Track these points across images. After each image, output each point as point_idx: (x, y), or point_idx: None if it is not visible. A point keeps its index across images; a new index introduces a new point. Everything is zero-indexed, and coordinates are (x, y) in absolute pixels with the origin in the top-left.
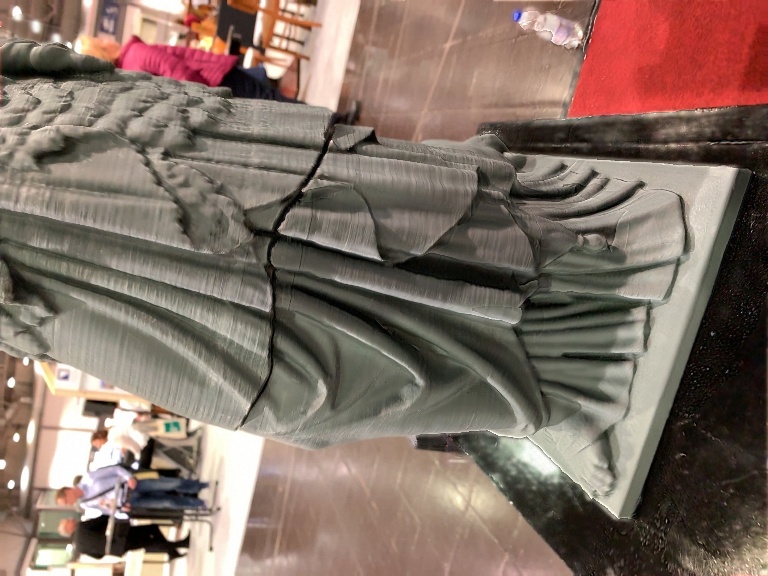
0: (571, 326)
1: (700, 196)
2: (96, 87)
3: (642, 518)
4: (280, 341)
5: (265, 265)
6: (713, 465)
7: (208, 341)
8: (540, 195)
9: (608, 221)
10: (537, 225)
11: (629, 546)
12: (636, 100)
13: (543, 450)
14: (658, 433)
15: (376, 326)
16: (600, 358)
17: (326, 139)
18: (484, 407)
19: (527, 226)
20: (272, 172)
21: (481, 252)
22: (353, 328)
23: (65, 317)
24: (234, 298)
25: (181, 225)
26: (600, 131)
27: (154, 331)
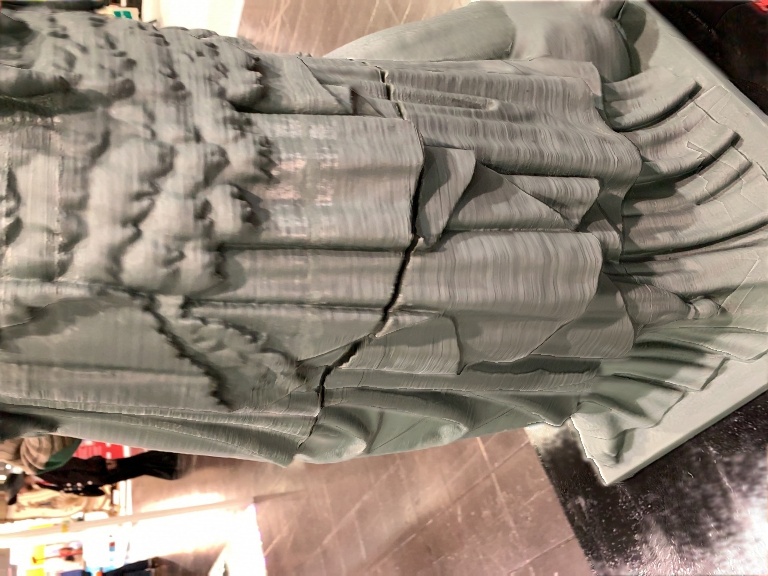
0: (634, 355)
1: None
2: (51, 160)
3: (628, 489)
4: (323, 421)
5: (316, 389)
6: (715, 503)
7: (241, 426)
8: (657, 178)
9: (731, 278)
10: (650, 306)
11: (606, 496)
12: None
13: None
14: (675, 446)
15: (430, 397)
16: (650, 382)
17: (414, 234)
18: (518, 421)
19: (638, 311)
20: (338, 313)
21: (574, 350)
22: (406, 408)
23: (69, 427)
24: (276, 413)
25: (216, 395)
26: None
27: (179, 432)
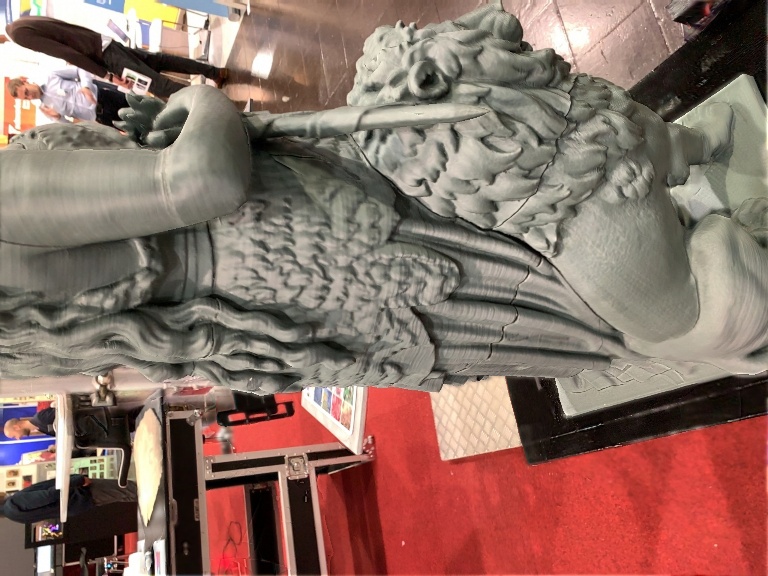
0: None
1: (565, 396)
2: None
3: None
4: None
5: None
6: None
7: None
8: None
9: None
10: None
11: None
12: None
13: None
14: None
15: None
16: None
17: None
18: None
19: None
20: None
21: None
22: None
23: None
24: None
25: None
26: (699, 411)
27: None
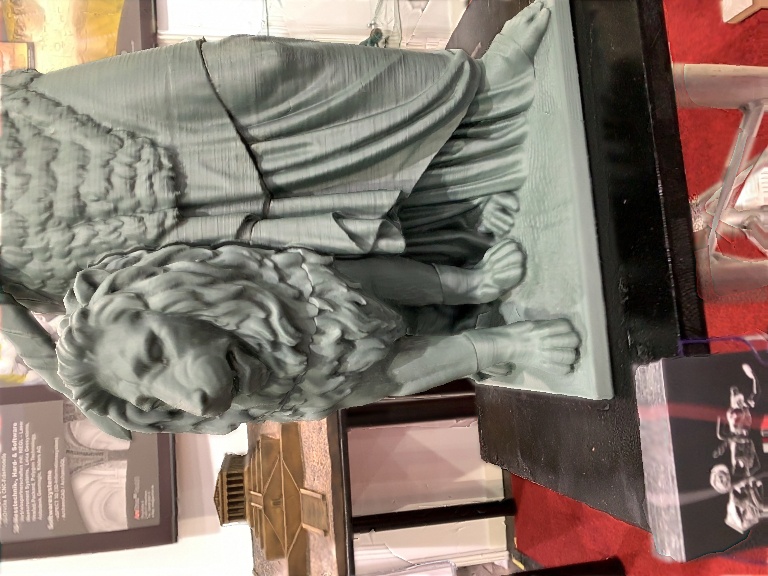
0: None
1: None
2: None
3: None
4: None
5: None
6: None
7: None
8: None
9: None
10: None
11: None
12: (701, 560)
13: (563, 101)
14: None
15: None
16: None
17: None
18: None
19: None
20: None
21: None
22: None
23: None
24: None
25: None
26: None
27: None
